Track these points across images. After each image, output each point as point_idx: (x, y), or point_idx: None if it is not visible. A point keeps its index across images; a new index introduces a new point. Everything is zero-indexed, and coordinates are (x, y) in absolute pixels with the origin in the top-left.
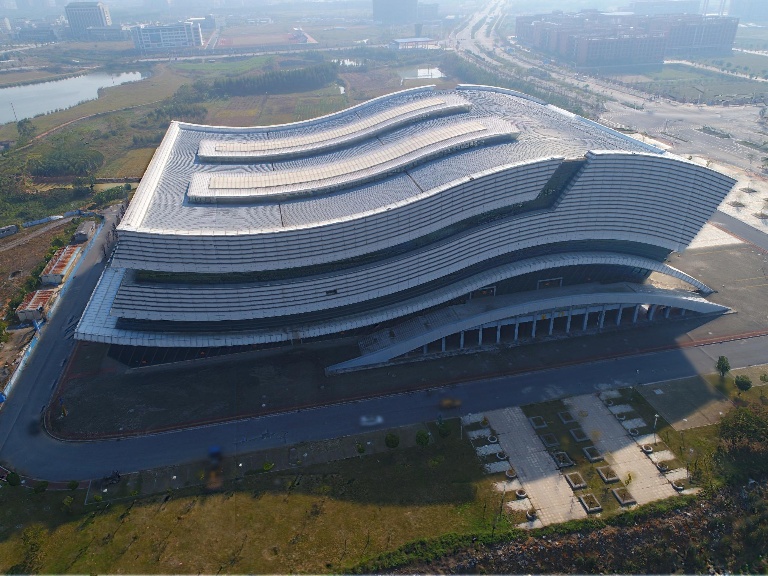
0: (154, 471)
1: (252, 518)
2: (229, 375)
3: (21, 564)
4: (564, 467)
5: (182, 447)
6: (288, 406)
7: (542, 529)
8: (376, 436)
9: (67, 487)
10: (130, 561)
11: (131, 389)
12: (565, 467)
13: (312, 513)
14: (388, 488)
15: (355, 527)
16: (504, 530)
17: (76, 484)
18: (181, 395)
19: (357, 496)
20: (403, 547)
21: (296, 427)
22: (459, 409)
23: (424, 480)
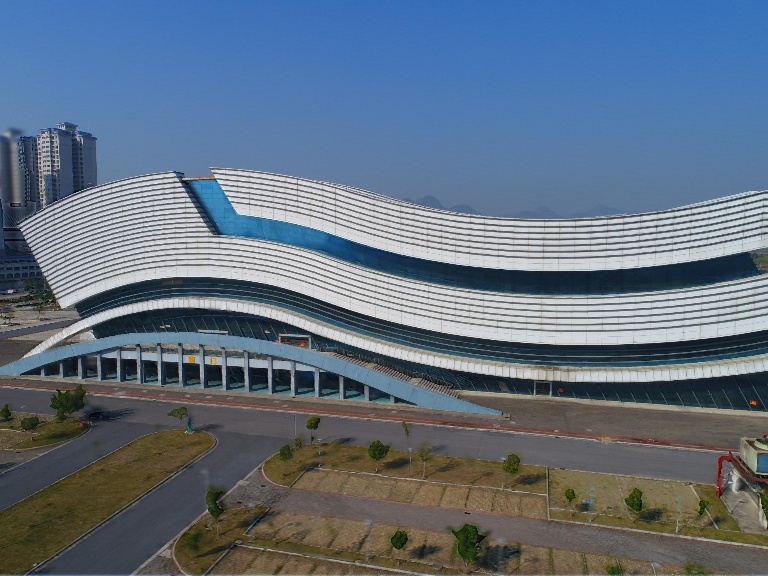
0: None
1: None
2: None
3: None
4: None
5: None
6: None
7: None
8: None
9: None
10: None
11: None
12: None
13: None
14: None
15: None
16: None
17: None
18: None
19: None
20: None
21: None
22: None
23: None
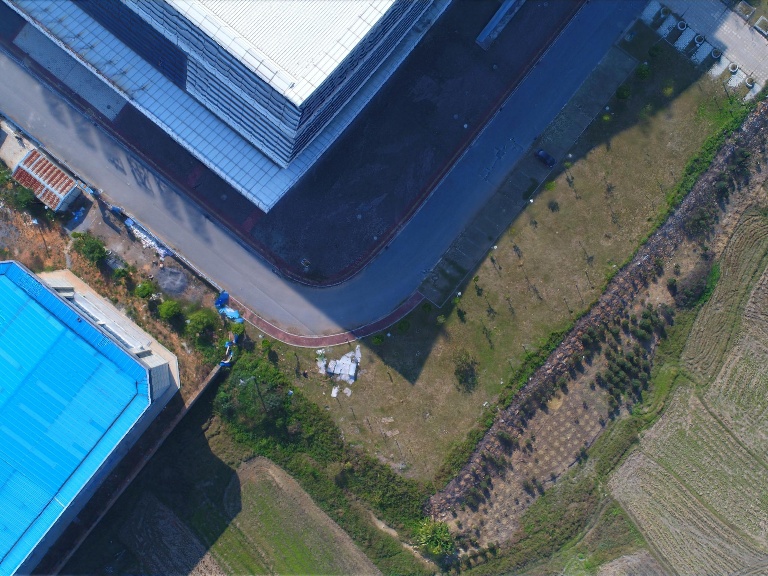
0: (453, 249)
1: (569, 228)
2: (397, 116)
3: (458, 368)
4: (750, 18)
5: (446, 214)
6: (487, 111)
7: (764, 91)
8: (588, 89)
9: (408, 308)
10: (525, 313)
11: (328, 198)
12: (750, 17)
13: (606, 193)
14: (640, 133)
15: (644, 181)
16: (739, 109)
17: (430, 306)
18: (382, 170)
19: (624, 156)
20: (686, 172)
21: (516, 128)
22: (631, 7)
23: (659, 107)
